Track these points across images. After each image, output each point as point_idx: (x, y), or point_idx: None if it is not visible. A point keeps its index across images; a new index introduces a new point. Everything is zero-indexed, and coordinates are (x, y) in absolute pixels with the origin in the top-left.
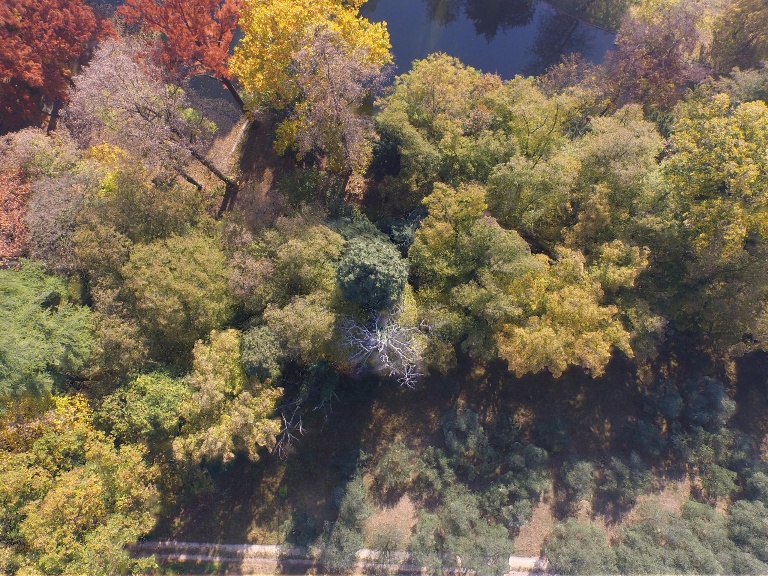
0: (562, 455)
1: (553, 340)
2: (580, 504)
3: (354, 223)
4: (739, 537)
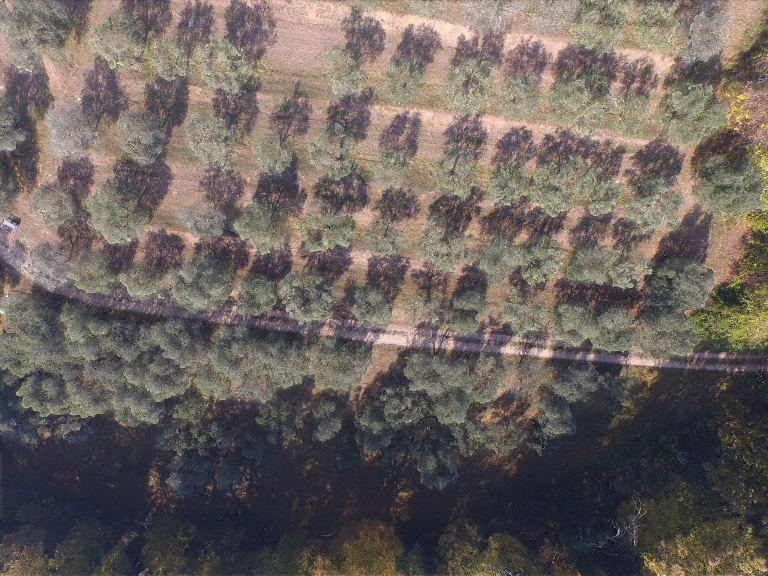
0: None
1: None
2: None
3: None
4: (184, 372)
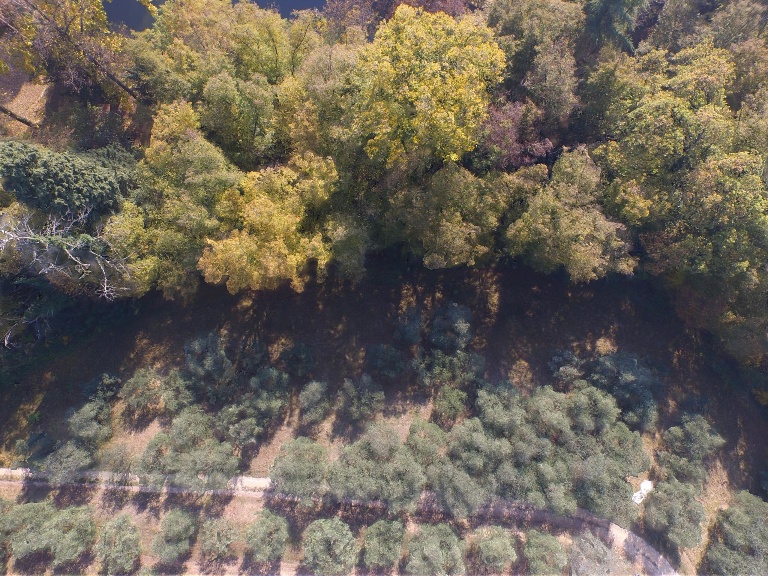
0: None
1: (237, 249)
2: (321, 427)
3: (98, 149)
4: (453, 452)
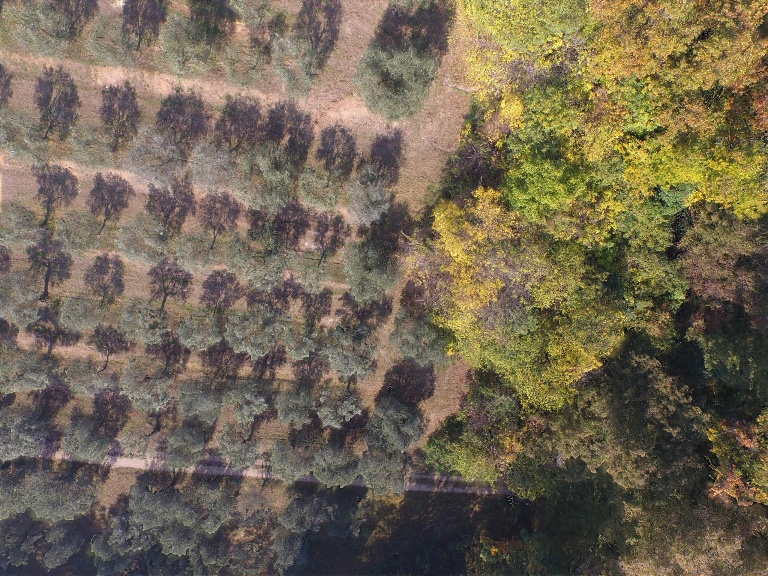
0: (86, 540)
1: None
2: None
3: None
4: None
